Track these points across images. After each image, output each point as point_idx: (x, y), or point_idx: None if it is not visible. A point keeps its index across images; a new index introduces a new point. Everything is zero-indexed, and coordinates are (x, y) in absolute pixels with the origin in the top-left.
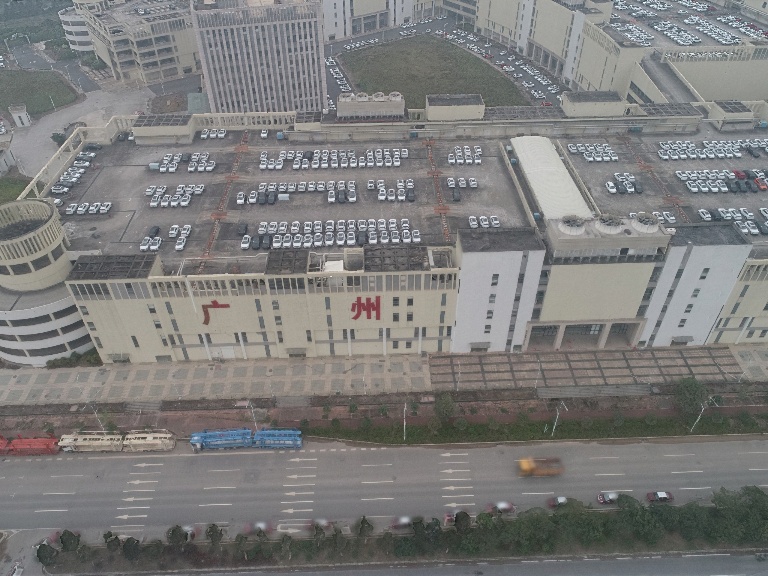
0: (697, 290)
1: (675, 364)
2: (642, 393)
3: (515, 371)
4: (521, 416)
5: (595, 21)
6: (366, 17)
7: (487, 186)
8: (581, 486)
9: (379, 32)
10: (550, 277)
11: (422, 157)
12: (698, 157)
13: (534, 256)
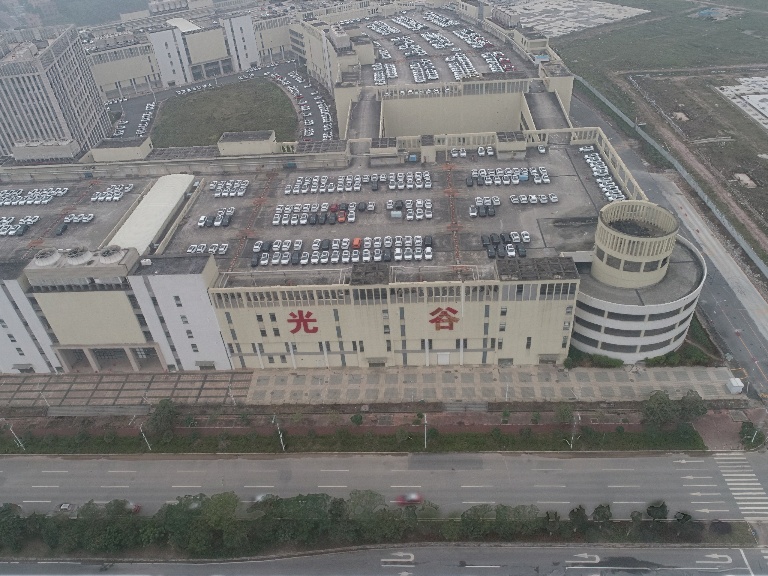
0: (184, 317)
1: (191, 387)
2: (141, 413)
3: (45, 391)
4: None
5: (349, 63)
6: (208, 64)
7: (100, 221)
8: (10, 496)
9: (222, 77)
10: (39, 304)
11: (77, 195)
12: (319, 191)
13: (10, 285)
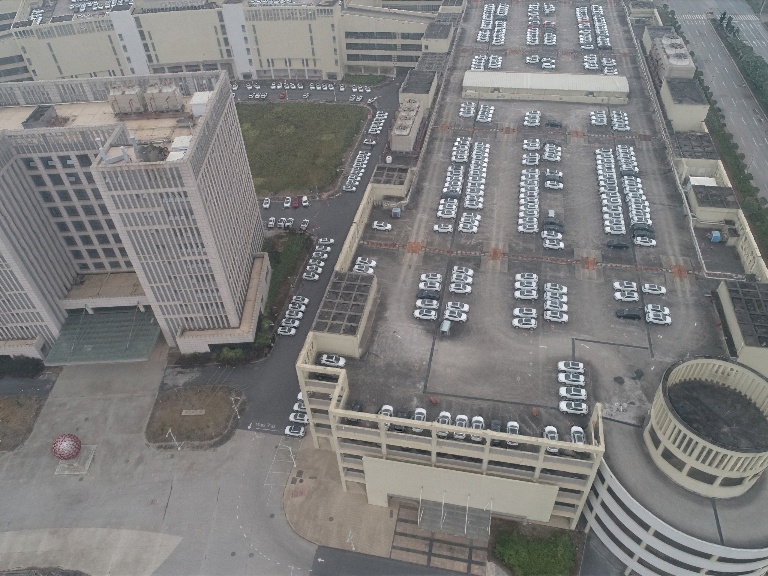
0: None
1: None
2: None
3: None
4: (750, 175)
5: None
6: None
7: None
8: None
9: None
10: None
11: (470, 134)
12: None
13: None
